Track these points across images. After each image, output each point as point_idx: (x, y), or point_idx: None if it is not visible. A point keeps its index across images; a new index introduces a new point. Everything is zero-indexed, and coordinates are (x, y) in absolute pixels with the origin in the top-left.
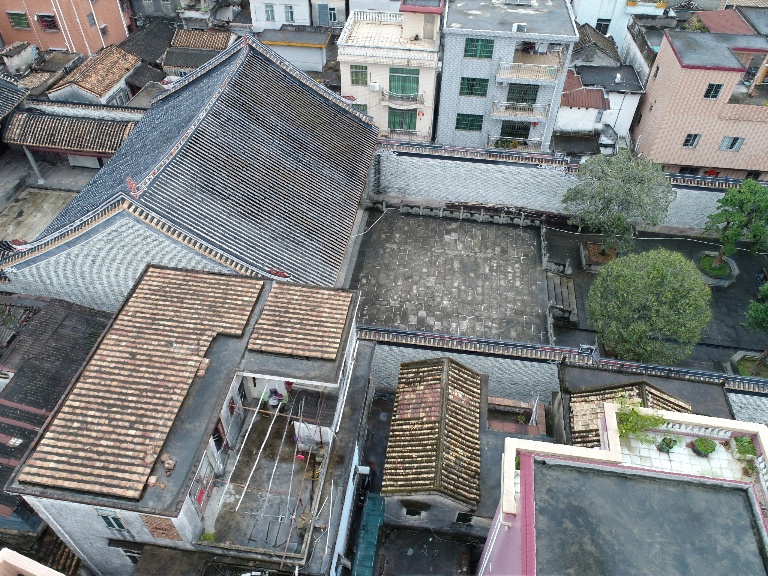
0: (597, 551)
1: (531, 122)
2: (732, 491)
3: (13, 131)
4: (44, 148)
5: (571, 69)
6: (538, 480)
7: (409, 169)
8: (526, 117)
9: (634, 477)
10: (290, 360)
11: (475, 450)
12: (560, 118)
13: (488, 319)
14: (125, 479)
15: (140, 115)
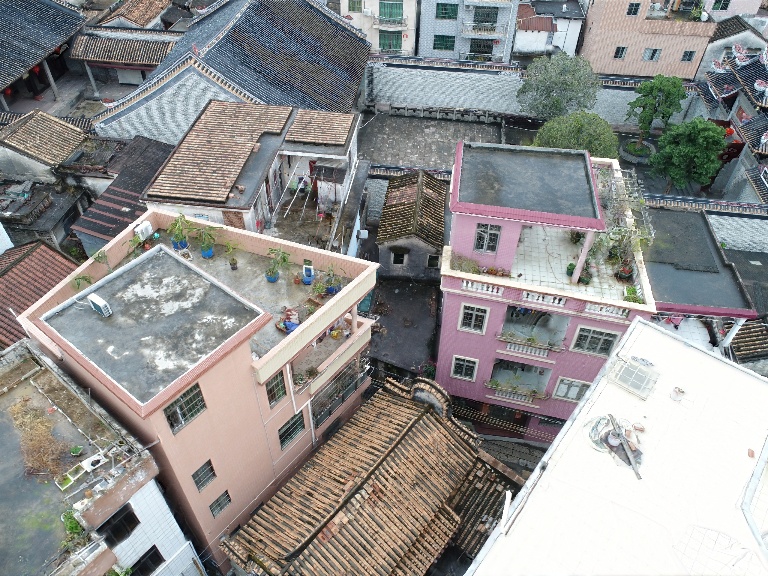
0: (496, 175)
1: (494, 41)
2: (577, 156)
3: (77, 49)
4: (102, 63)
5: (528, 3)
6: (466, 153)
7: (396, 79)
8: (489, 35)
9: (522, 152)
10: (314, 146)
11: (441, 221)
12: (518, 40)
13: None
14: (215, 193)
15: (178, 37)
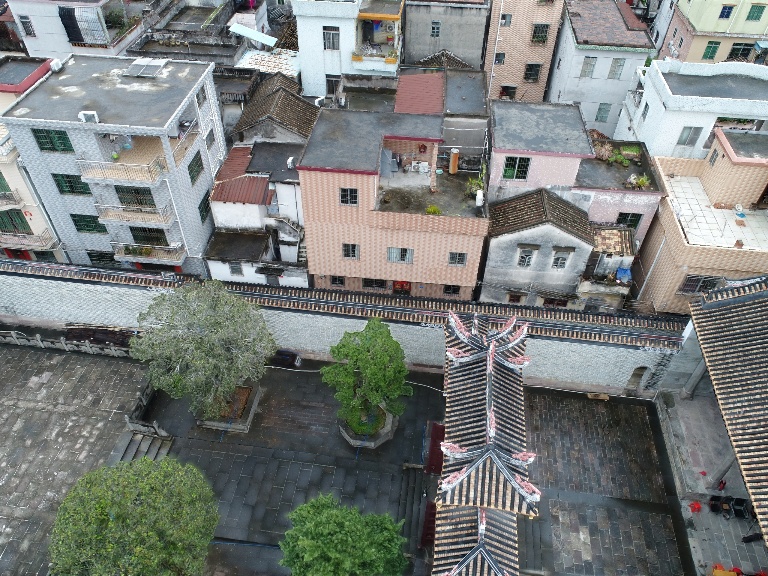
0: None
1: None
2: None
3: None
4: None
5: (251, 147)
6: None
7: (2, 287)
8: (141, 222)
9: None
10: None
11: None
12: (217, 213)
13: (5, 519)
14: None
15: None
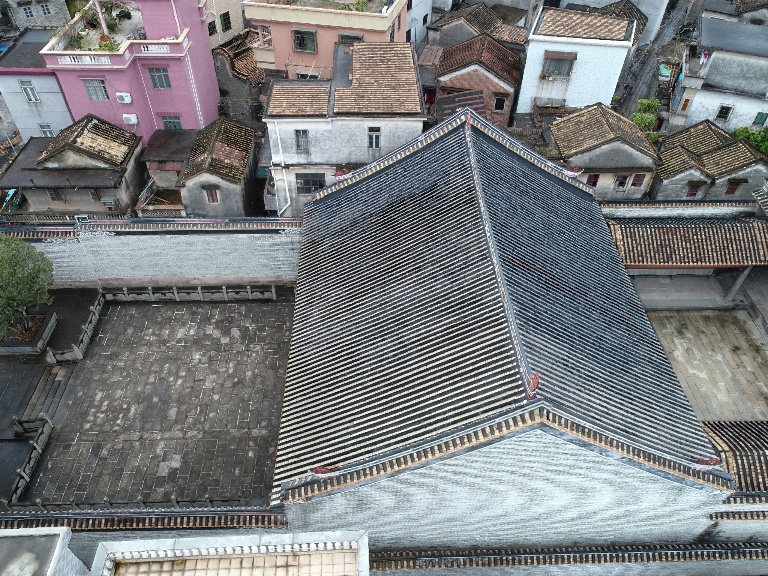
0: None
1: None
2: None
3: None
4: None
5: None
6: None
7: None
8: None
9: None
10: None
11: None
12: None
13: (152, 343)
14: None
15: None
